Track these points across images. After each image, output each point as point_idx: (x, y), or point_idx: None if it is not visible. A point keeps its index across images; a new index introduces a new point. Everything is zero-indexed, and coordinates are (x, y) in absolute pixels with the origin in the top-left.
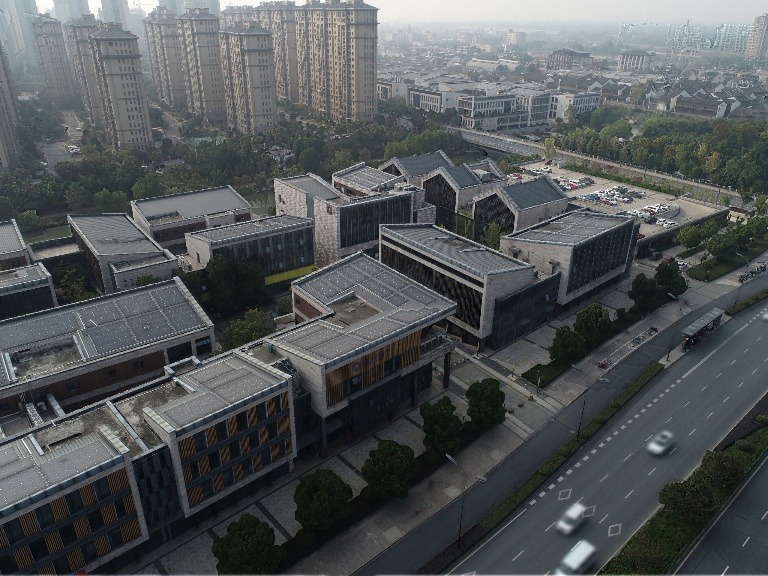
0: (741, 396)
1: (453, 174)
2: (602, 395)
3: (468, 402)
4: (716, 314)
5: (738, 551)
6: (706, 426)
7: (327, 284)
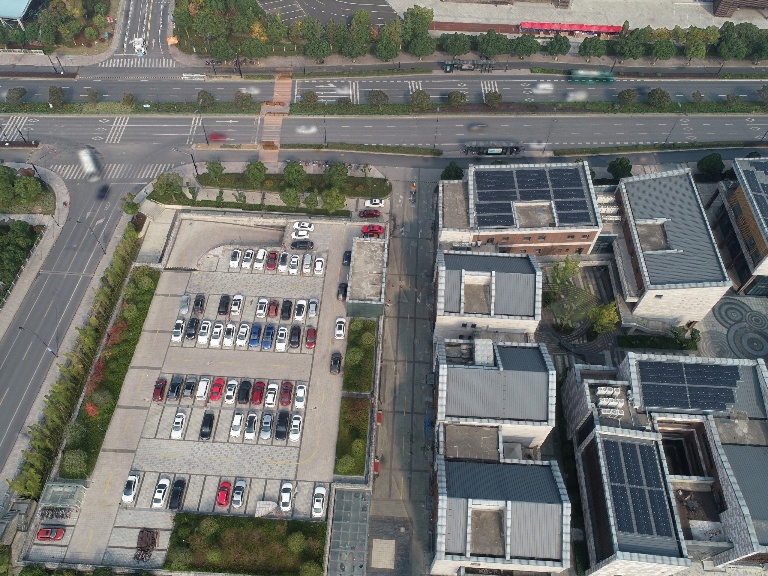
0: (539, 122)
1: (535, 364)
2: (613, 160)
3: (699, 194)
4: (477, 142)
5: (645, 96)
6: (584, 123)
7: None
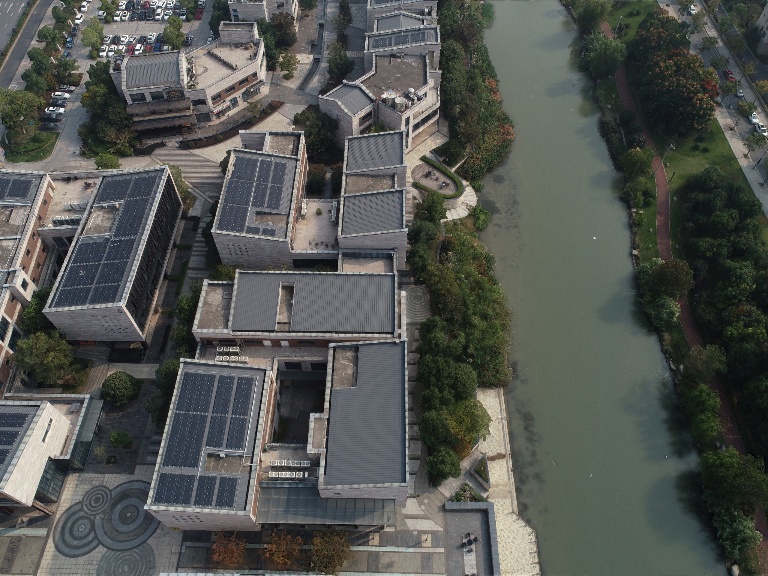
0: None
1: None
2: None
3: None
4: None
5: None
6: None
7: (5, 425)
